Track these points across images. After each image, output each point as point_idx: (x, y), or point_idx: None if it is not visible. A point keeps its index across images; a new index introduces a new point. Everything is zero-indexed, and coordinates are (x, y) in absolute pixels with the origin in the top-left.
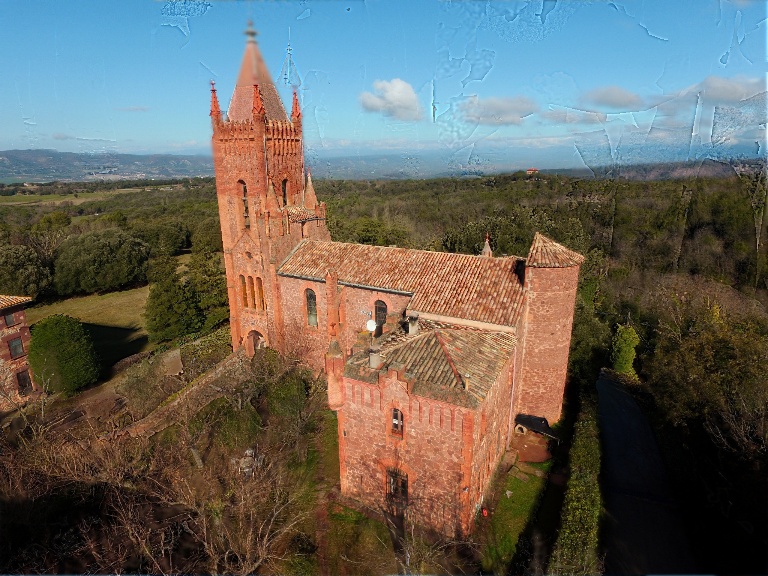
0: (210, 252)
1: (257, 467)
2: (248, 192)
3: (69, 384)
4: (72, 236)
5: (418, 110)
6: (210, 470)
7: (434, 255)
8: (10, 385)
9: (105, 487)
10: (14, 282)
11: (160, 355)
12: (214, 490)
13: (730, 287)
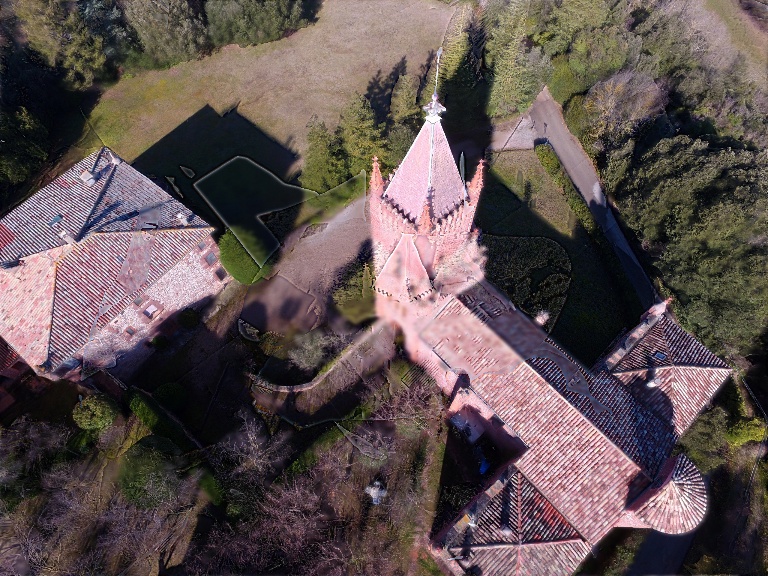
0: (364, 113)
1: (381, 496)
2: None
3: None
4: None
5: None
6: (352, 483)
7: (568, 409)
8: (213, 279)
9: (298, 565)
10: (175, 41)
11: None
12: (354, 505)
13: None
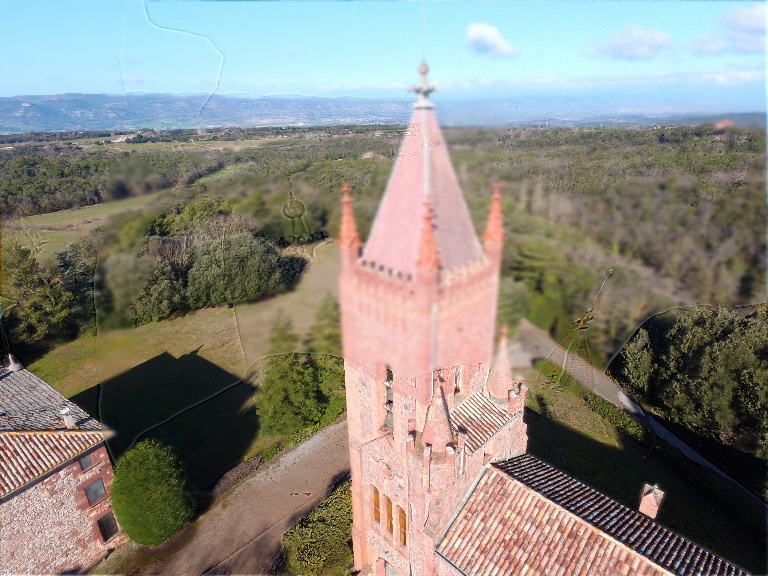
0: None
1: None
2: (395, 385)
3: (155, 538)
4: None
5: None
6: None
7: None
8: (89, 535)
9: None
10: None
11: (270, 462)
12: None
13: None
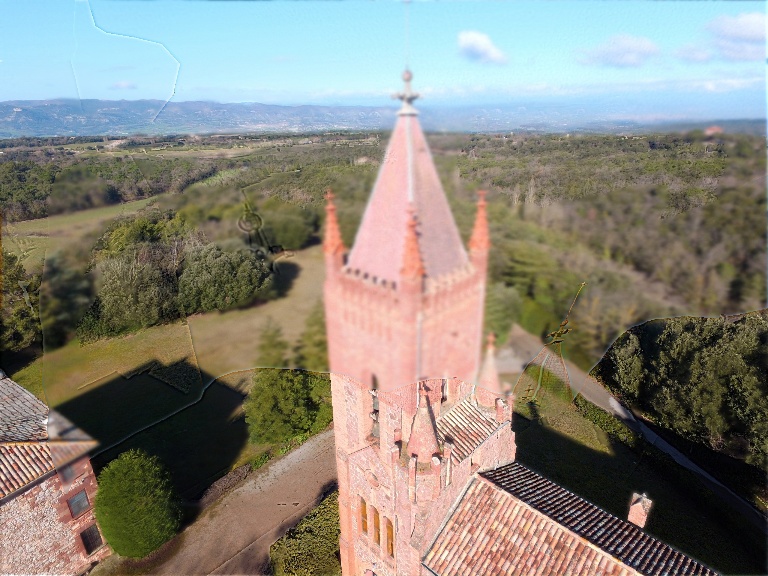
0: None
1: None
2: (380, 395)
3: (139, 550)
4: None
5: None
6: None
7: None
8: (72, 549)
9: None
10: None
11: (259, 471)
12: None
13: None
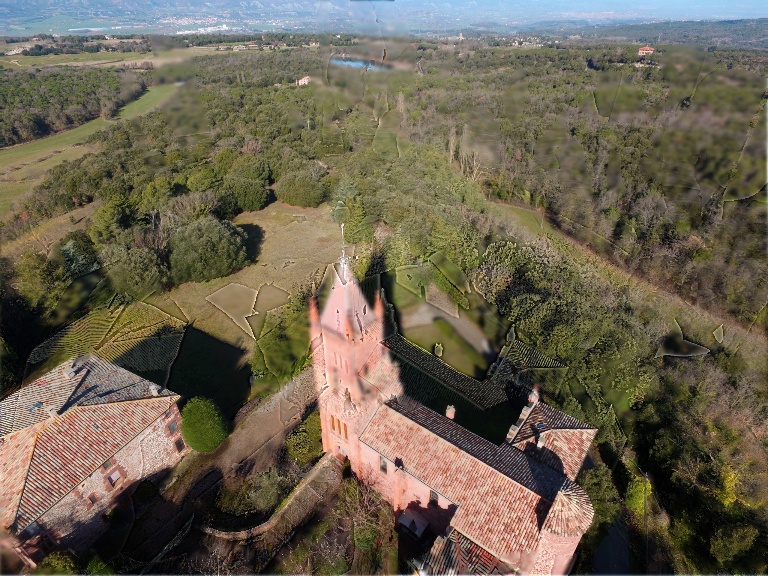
0: None
1: None
2: None
3: (209, 448)
4: (180, 229)
5: (505, 109)
6: None
7: None
8: (172, 450)
9: None
10: None
11: (265, 400)
12: None
13: (758, 442)
